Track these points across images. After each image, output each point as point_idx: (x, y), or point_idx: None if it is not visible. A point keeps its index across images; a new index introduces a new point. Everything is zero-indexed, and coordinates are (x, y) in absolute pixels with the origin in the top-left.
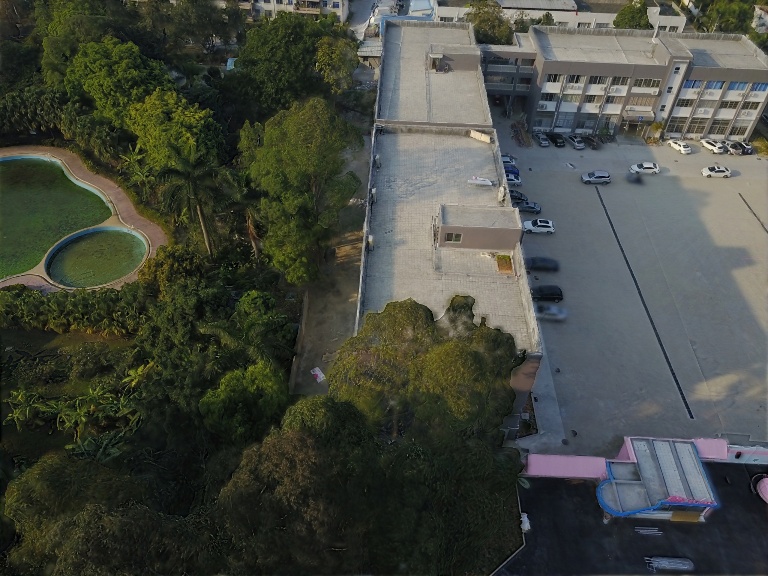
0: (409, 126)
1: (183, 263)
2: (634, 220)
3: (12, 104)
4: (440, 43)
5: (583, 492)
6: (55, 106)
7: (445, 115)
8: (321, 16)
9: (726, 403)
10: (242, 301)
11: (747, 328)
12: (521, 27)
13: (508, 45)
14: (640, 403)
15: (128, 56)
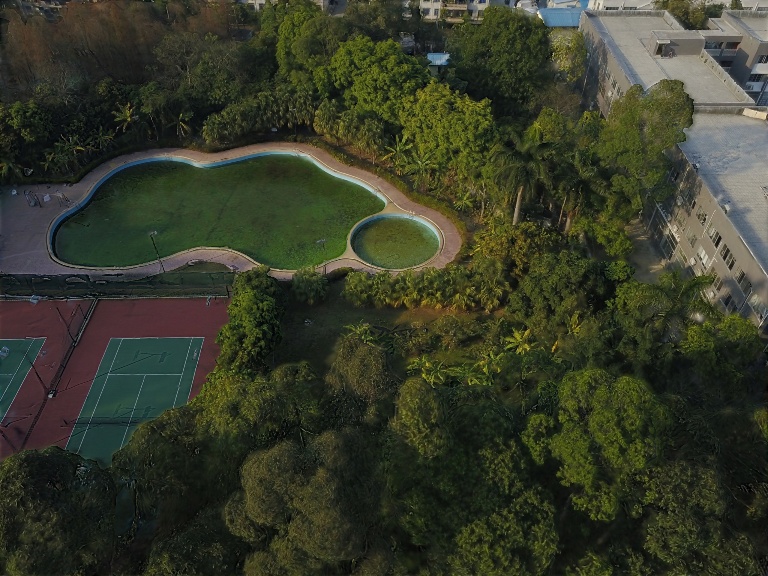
0: None
1: (534, 239)
2: None
3: (265, 103)
4: (660, 30)
5: None
6: (307, 103)
7: (698, 96)
8: (467, 12)
9: None
10: (614, 270)
11: None
12: (703, 13)
13: (710, 30)
14: None
15: (393, 52)
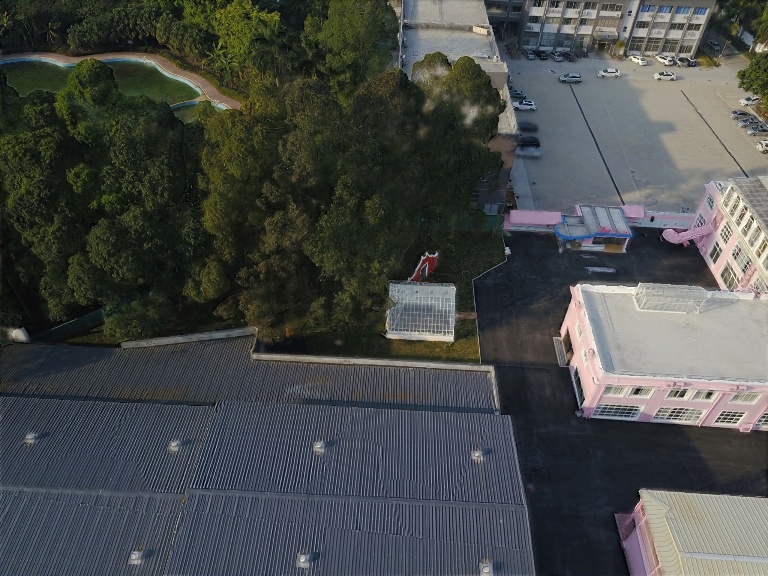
0: (427, 23)
1: None
2: (597, 105)
3: (118, 16)
4: None
5: (547, 239)
6: (152, 18)
7: (454, 21)
8: None
9: (651, 202)
10: None
11: (673, 165)
12: None
13: None
14: (591, 201)
15: None
